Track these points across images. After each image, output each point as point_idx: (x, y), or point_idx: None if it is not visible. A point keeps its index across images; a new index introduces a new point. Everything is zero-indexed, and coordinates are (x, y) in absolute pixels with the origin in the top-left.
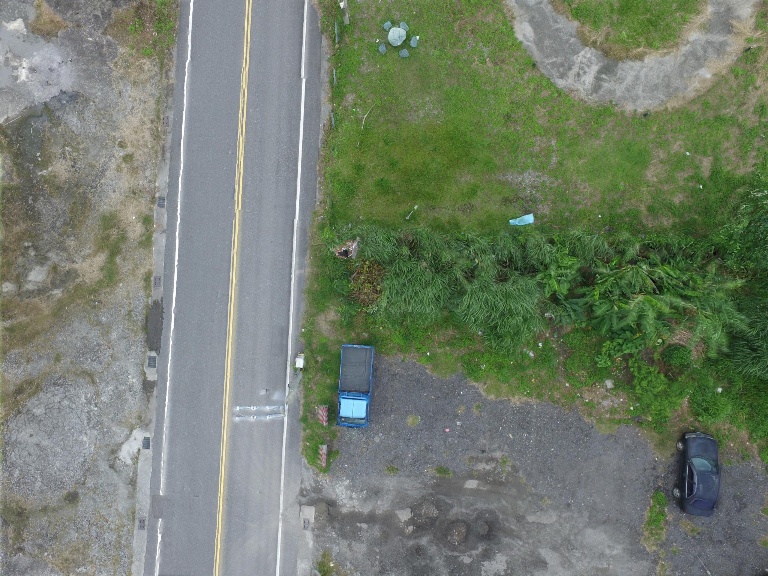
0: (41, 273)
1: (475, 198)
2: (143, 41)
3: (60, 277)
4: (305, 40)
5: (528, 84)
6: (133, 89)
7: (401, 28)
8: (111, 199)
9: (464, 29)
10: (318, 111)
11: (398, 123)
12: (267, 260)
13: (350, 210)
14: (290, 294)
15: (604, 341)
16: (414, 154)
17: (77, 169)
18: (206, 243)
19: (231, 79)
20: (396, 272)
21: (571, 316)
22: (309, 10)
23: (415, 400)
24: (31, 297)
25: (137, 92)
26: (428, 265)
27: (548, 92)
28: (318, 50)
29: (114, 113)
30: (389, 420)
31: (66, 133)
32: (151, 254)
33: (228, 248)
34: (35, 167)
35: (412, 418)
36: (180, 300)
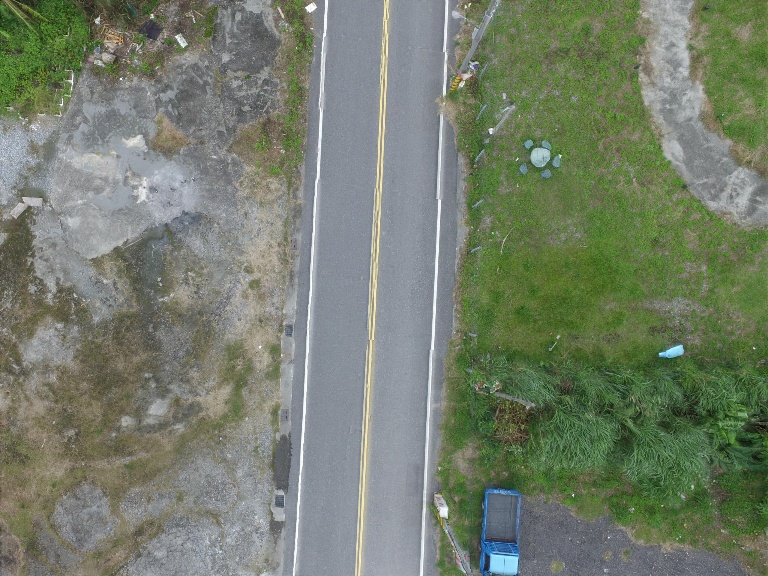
0: (162, 406)
1: (621, 328)
2: (270, 159)
3: (182, 411)
4: (441, 158)
5: (677, 206)
6: (259, 210)
7: (545, 148)
8: (236, 327)
9: (609, 147)
10: (454, 234)
11: (539, 247)
12: (401, 393)
13: (489, 340)
14: (425, 429)
15: (762, 485)
16: (556, 280)
17: (200, 295)
18: (337, 375)
19: (363, 200)
20: (557, 425)
21: (735, 465)
22: (445, 126)
23: (559, 545)
24: (152, 432)
25: (263, 213)
26: (590, 417)
27: (698, 215)
28: (454, 169)
29: (239, 236)
30: (531, 566)
31: (189, 257)
32: (278, 386)
33: (360, 381)
34: (156, 293)
35: (556, 564)
36: (309, 435)
